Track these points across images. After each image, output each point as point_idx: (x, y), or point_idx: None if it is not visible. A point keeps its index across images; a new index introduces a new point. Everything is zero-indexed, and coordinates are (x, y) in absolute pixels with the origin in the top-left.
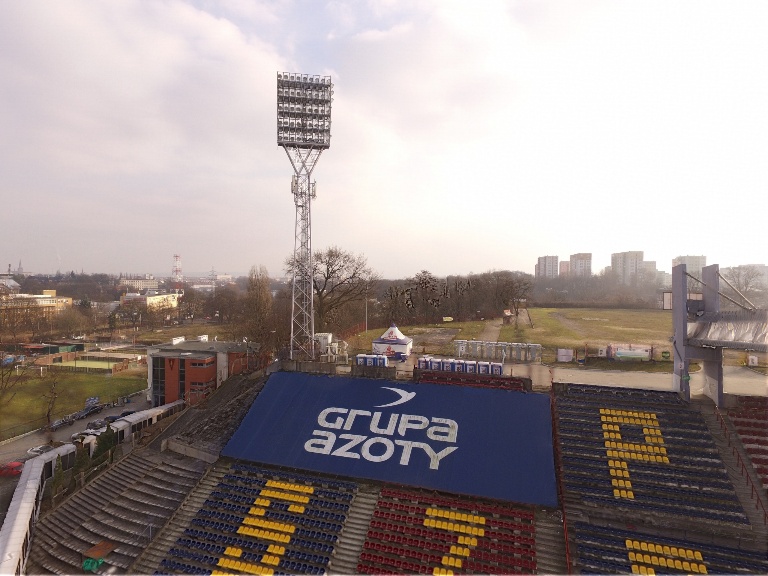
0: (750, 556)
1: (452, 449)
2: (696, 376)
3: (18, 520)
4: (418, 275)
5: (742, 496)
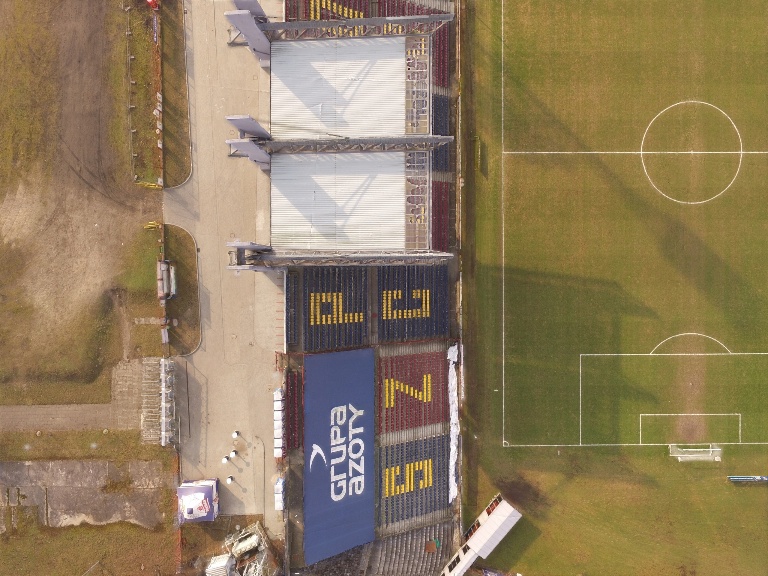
0: (380, 272)
1: (351, 406)
2: (205, 239)
3: None
4: None
5: None
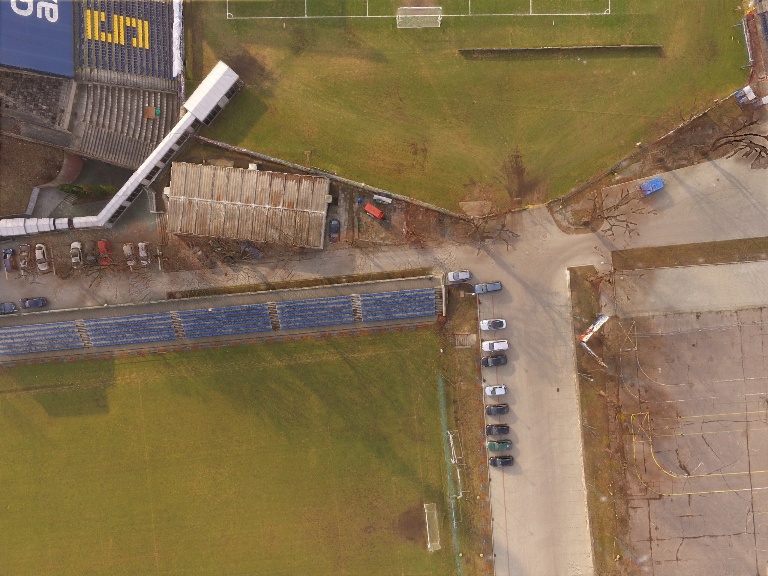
0: None
1: None
2: None
3: (150, 160)
4: None
5: None
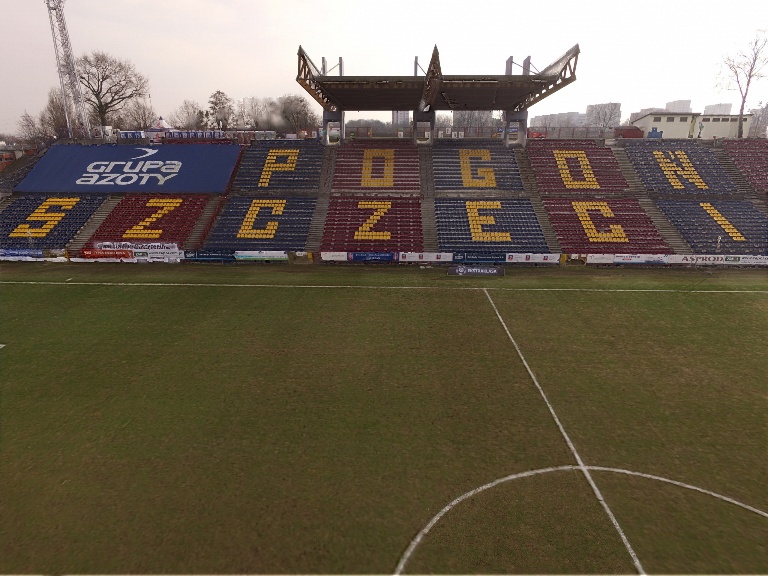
0: (308, 199)
1: (174, 175)
2: None
3: None
4: (213, 95)
5: (322, 180)
